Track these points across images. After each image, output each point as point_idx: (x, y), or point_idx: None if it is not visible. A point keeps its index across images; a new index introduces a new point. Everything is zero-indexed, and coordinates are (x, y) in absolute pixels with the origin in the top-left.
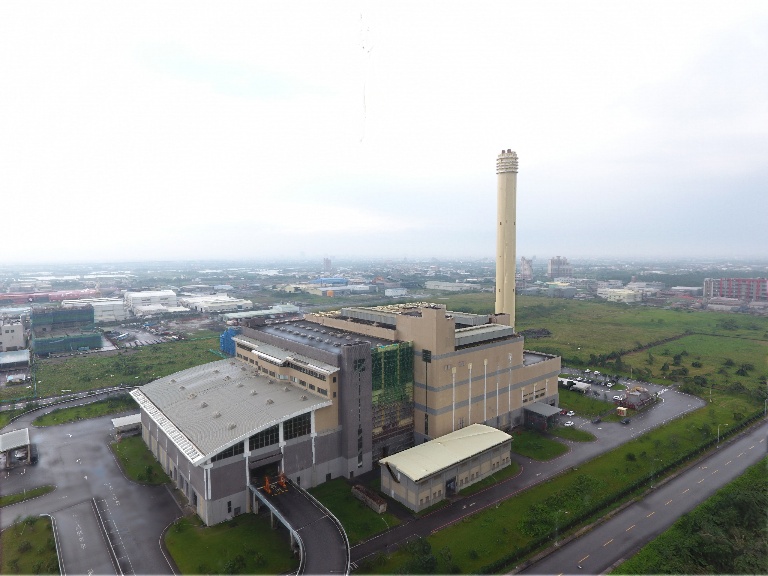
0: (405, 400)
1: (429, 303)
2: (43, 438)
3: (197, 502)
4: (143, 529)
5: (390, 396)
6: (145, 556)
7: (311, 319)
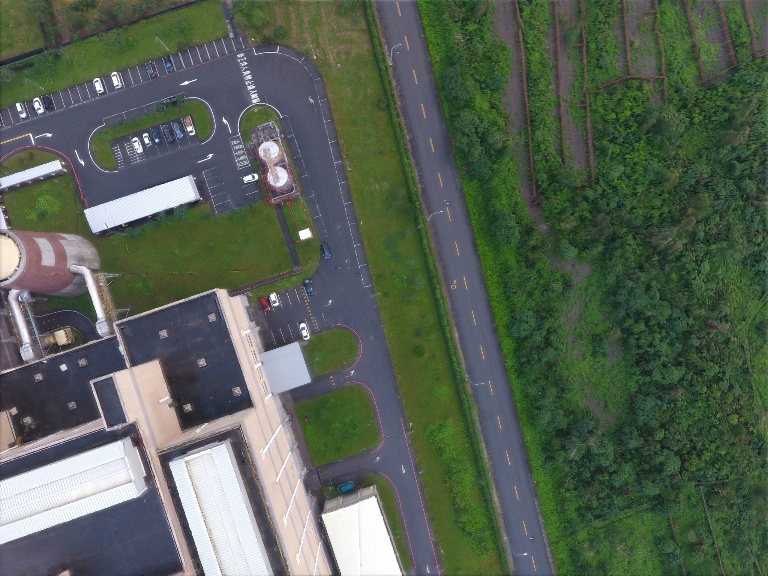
0: None
1: None
2: None
3: None
4: None
5: None
6: None
7: None
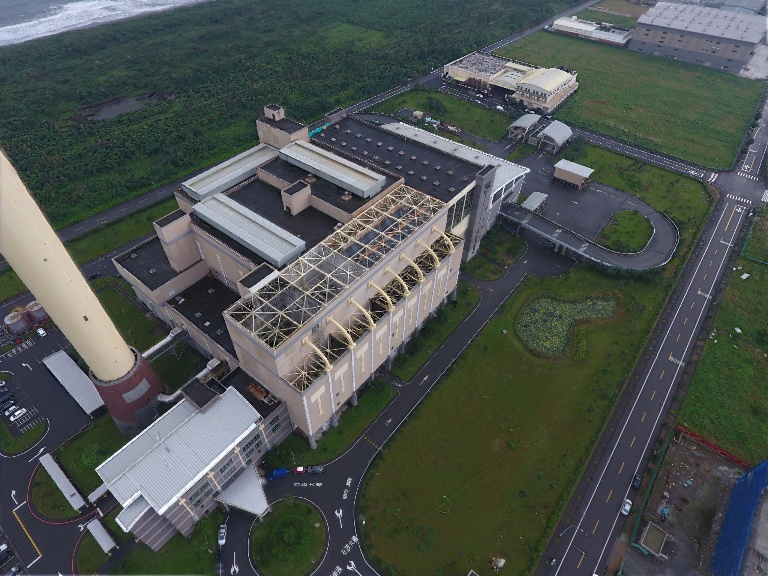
0: None
1: (255, 331)
2: (591, 198)
3: None
4: None
5: None
6: None
7: None
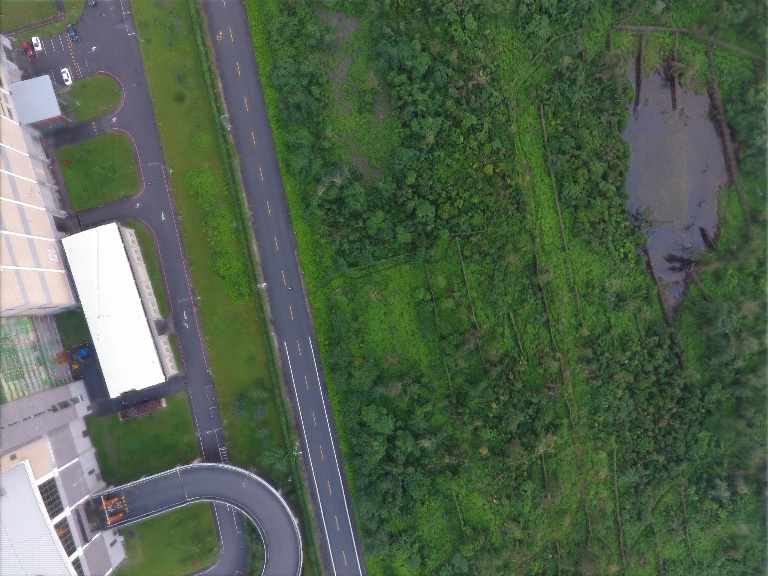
0: (7, 334)
1: None
2: None
3: None
4: None
5: (3, 360)
6: None
7: None
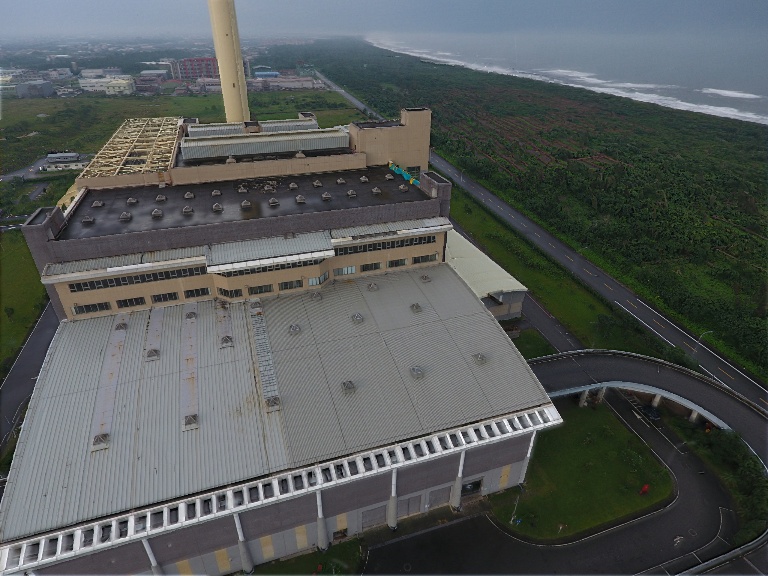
0: None
1: None
2: None
3: (487, 483)
4: (520, 574)
5: None
6: (594, 563)
7: (112, 183)
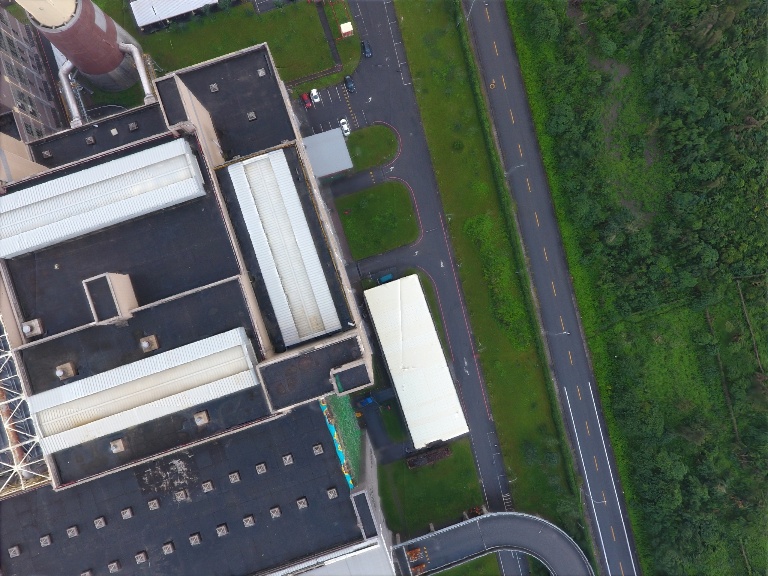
0: None
1: None
2: None
3: None
4: None
5: None
6: None
7: None
